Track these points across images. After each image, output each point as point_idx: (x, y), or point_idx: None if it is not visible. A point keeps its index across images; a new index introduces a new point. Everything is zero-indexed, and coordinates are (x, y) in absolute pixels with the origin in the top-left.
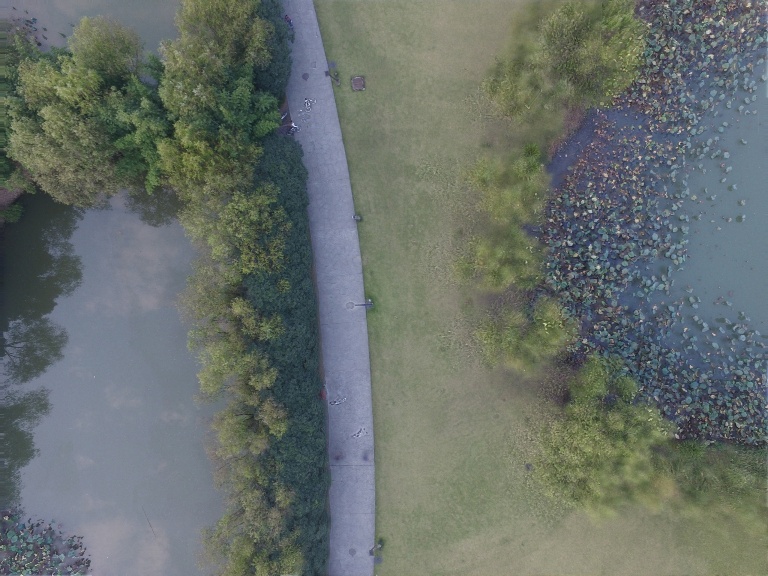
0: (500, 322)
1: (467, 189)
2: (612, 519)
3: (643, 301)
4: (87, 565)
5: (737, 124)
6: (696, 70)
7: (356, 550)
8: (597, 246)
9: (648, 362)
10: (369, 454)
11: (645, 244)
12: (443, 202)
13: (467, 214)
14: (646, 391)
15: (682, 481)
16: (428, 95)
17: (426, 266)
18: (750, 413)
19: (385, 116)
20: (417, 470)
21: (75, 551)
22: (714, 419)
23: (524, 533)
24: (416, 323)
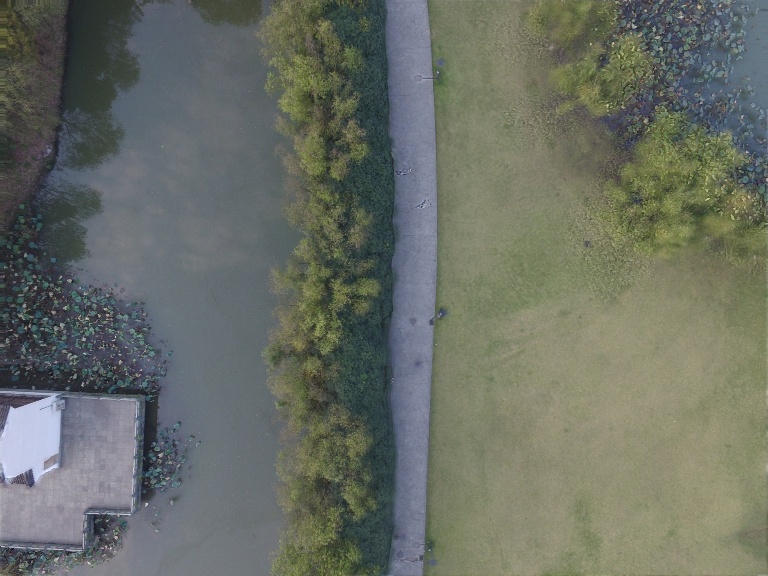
0: (563, 103)
1: None
2: (667, 297)
3: (703, 86)
4: (149, 329)
5: None
6: None
7: (417, 319)
8: (661, 27)
9: (706, 144)
10: (432, 225)
11: (707, 30)
12: None
13: None
14: (704, 170)
15: (735, 265)
16: None
17: (493, 44)
18: None
19: None
20: (479, 240)
21: (138, 314)
22: None
23: (581, 306)
24: (482, 98)
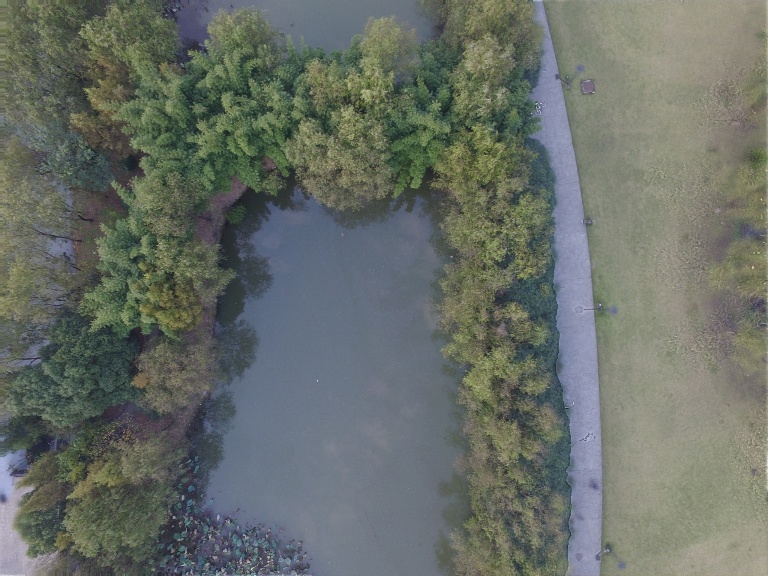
0: (724, 327)
1: (693, 194)
2: None
3: None
4: (310, 569)
5: None
6: None
7: (583, 555)
8: None
9: None
10: (597, 459)
11: None
12: (670, 207)
13: (693, 219)
14: None
15: None
16: (658, 99)
17: (653, 271)
18: None
19: (614, 120)
20: (647, 475)
21: (299, 555)
22: None
23: (751, 538)
24: (644, 328)
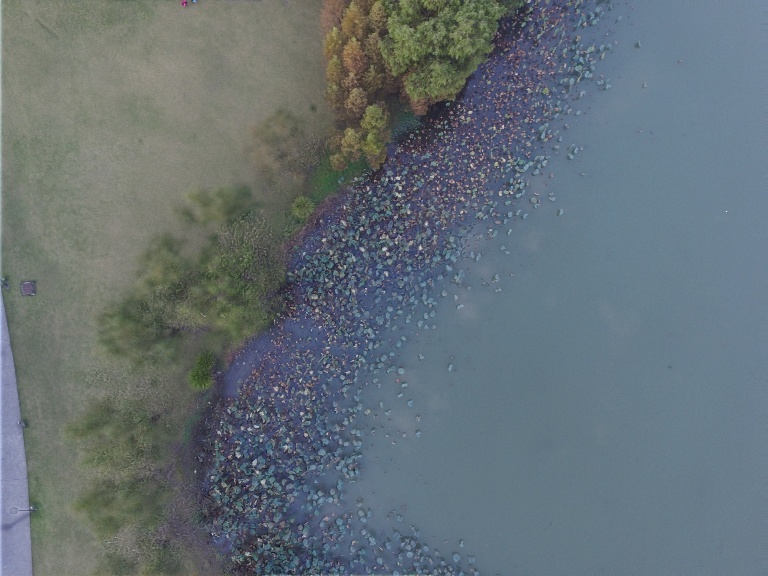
0: (170, 528)
1: (139, 396)
2: None
3: (310, 514)
4: None
5: (416, 338)
6: (370, 287)
7: None
8: (261, 462)
9: None
10: None
11: (313, 458)
12: (114, 408)
13: (139, 421)
14: None
15: None
16: (99, 302)
17: (94, 472)
18: None
19: (55, 322)
20: None
21: None
22: None
23: None
24: (81, 529)
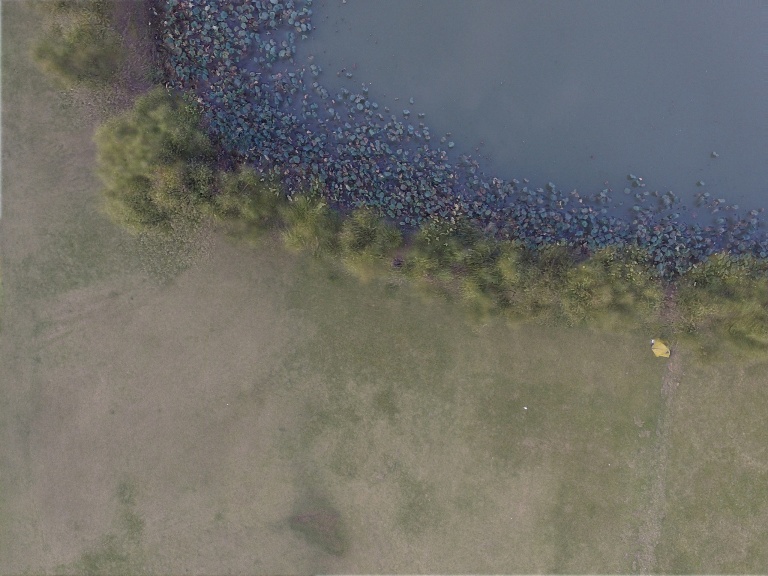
0: (125, 84)
1: None
2: (225, 279)
3: (263, 65)
4: None
5: None
6: None
7: None
8: (213, 5)
9: (263, 123)
10: None
11: (266, 8)
12: None
13: None
14: (256, 150)
15: (299, 246)
16: None
17: (51, 24)
18: (360, 176)
19: None
20: (29, 220)
21: None
22: (324, 181)
23: (134, 287)
24: (37, 78)
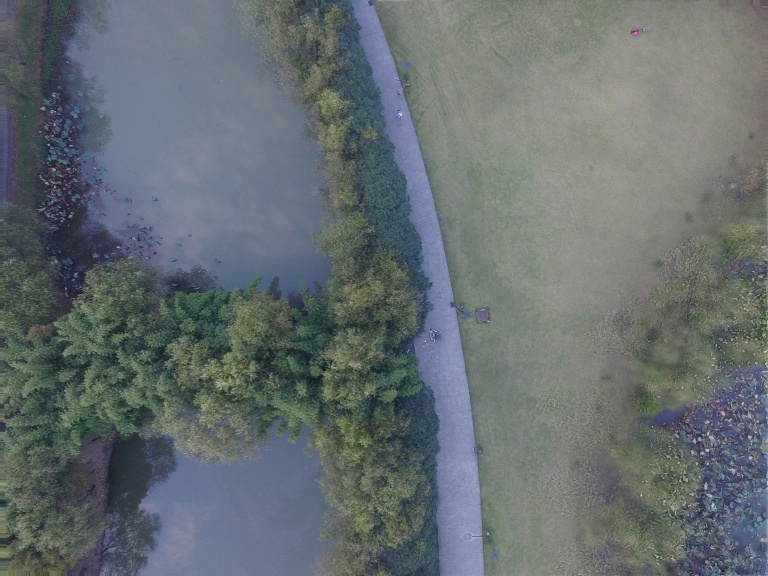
0: (612, 552)
1: (585, 421)
2: None
3: (753, 536)
4: None
5: None
6: None
7: None
8: (713, 485)
9: None
10: None
11: (758, 481)
12: (562, 434)
13: (584, 445)
14: None
15: None
16: (552, 329)
17: (543, 497)
18: None
19: (508, 348)
20: None
21: None
22: None
23: None
24: (532, 554)
